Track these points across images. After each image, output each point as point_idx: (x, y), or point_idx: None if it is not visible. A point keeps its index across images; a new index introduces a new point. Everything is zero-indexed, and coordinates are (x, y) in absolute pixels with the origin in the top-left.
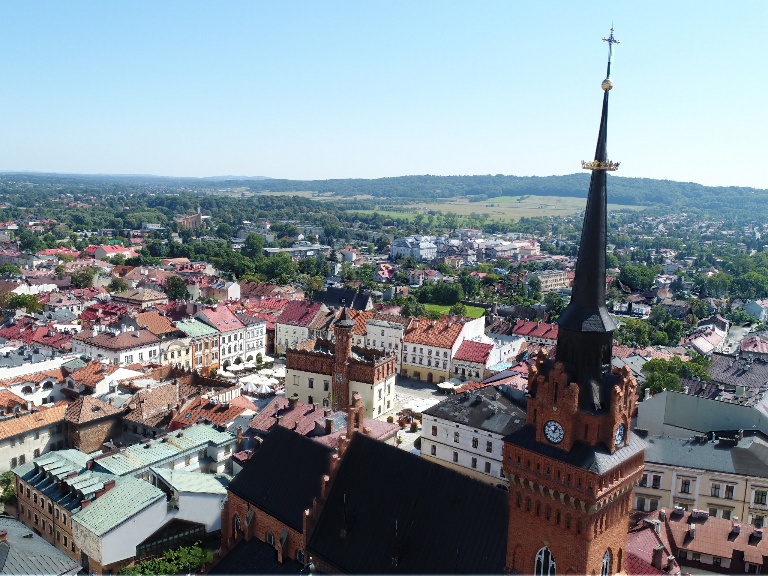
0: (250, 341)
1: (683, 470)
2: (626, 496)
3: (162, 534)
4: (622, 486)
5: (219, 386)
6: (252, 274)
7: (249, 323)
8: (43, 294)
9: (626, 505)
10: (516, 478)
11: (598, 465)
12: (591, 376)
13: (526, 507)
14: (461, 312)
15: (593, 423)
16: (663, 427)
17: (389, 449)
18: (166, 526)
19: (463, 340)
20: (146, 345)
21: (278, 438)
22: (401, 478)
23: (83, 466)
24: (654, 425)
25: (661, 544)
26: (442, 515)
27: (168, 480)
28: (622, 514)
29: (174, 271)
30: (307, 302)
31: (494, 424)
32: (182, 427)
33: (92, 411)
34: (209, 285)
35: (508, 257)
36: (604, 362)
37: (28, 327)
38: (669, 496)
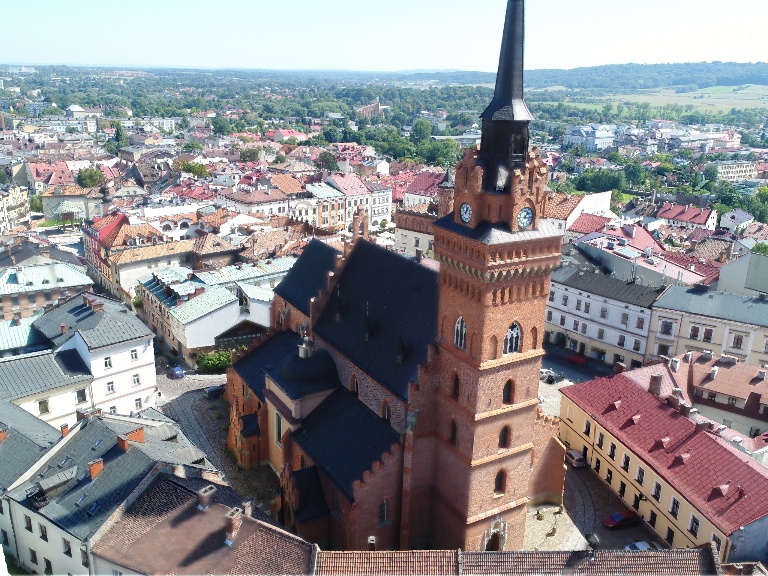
0: (376, 207)
1: (736, 324)
2: (540, 279)
3: (237, 332)
4: (527, 265)
5: (325, 235)
6: (411, 157)
7: (375, 190)
8: (212, 164)
9: (541, 288)
10: (441, 257)
11: (491, 238)
12: (501, 163)
13: (449, 283)
14: (616, 199)
15: (493, 202)
16: (743, 291)
17: (380, 250)
18: (240, 326)
19: (581, 213)
20: (276, 202)
21: (313, 249)
22: (384, 273)
23: (186, 278)
24: (735, 289)
25: (672, 378)
26: (405, 300)
27: (245, 290)
28: (535, 295)
29: (335, 151)
30: (435, 174)
31: (559, 275)
32: (273, 257)
33: (213, 246)
34: (360, 162)
35: (693, 148)
36: (517, 151)
37: (189, 187)
38: (720, 350)
